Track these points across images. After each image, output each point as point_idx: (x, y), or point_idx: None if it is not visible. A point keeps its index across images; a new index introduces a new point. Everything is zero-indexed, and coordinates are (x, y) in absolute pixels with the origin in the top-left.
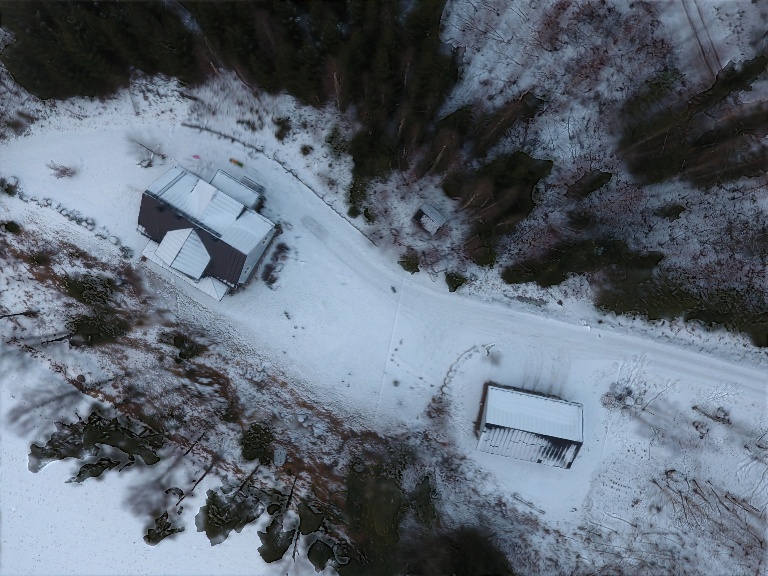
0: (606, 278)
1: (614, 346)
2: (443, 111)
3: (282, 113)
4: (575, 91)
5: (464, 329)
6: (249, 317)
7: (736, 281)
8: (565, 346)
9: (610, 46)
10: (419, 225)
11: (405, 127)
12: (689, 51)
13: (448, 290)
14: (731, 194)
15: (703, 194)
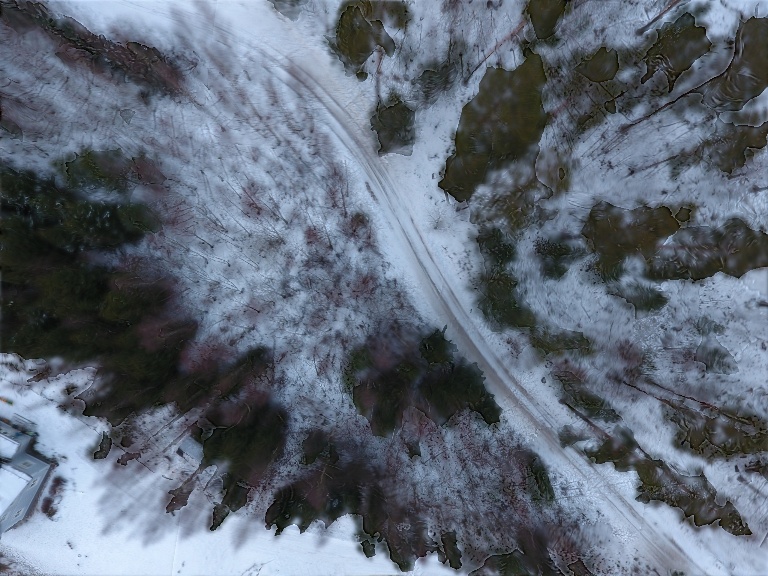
0: None
1: (387, 559)
2: (192, 353)
3: None
4: (316, 331)
5: (244, 548)
6: (34, 548)
7: (500, 493)
8: (340, 561)
9: (344, 288)
10: None
11: (123, 406)
12: (422, 289)
13: None
14: None
15: (457, 416)
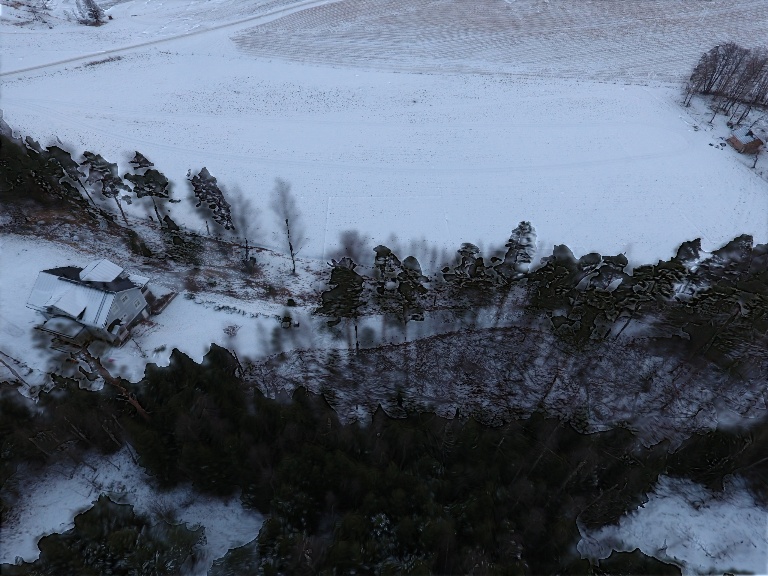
0: None
1: None
2: None
3: None
4: None
5: None
6: None
7: None
8: None
9: None
10: None
11: None
12: None
13: None
14: None
15: None
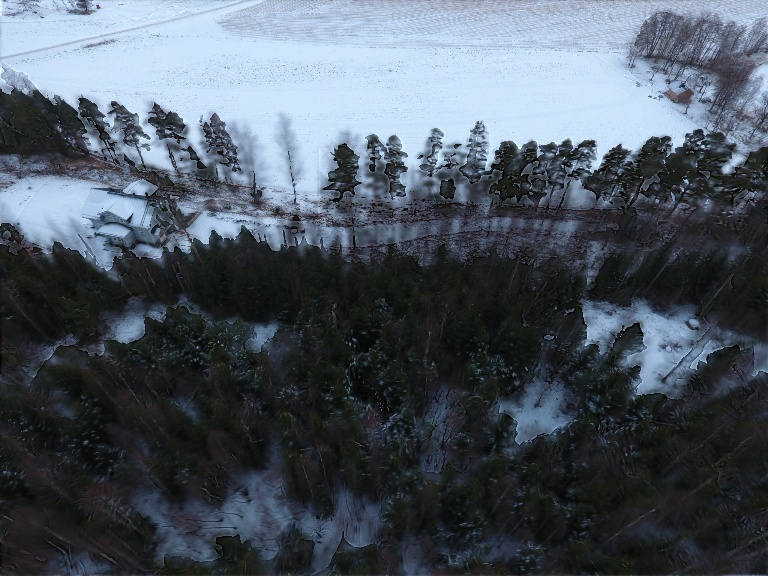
0: None
1: None
2: None
3: None
4: None
5: None
6: None
7: None
8: None
9: None
10: None
11: None
12: None
13: None
14: None
15: None
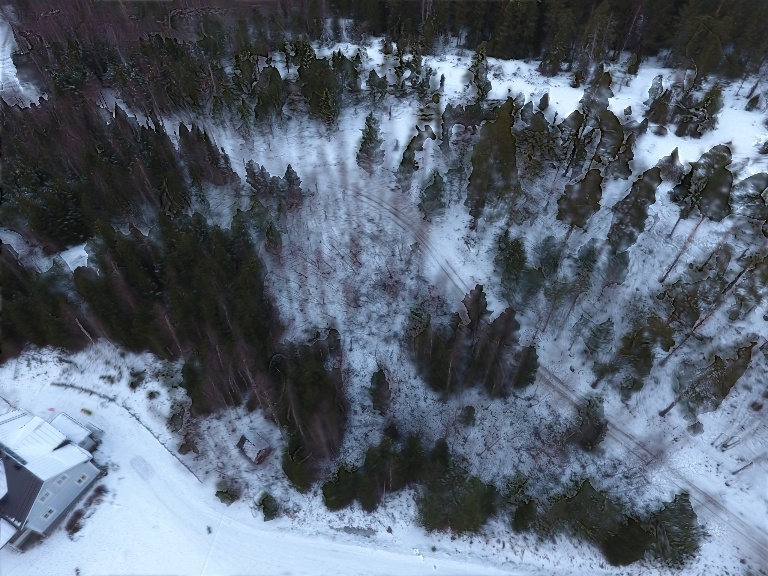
0: (432, 495)
1: None
2: None
3: (140, 366)
4: (378, 332)
5: (282, 574)
6: None
7: (563, 487)
8: None
9: (400, 302)
10: (246, 456)
11: (222, 355)
12: (459, 301)
13: (269, 526)
14: (528, 402)
15: (503, 404)
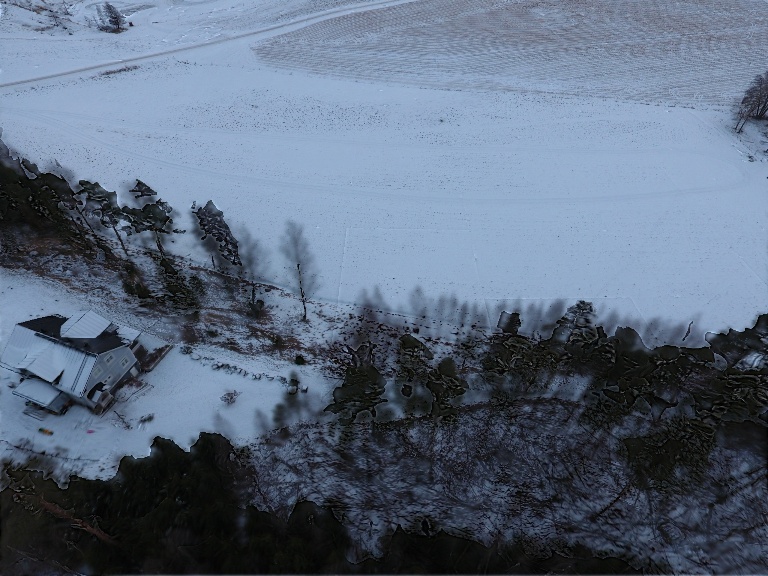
0: None
1: None
2: None
3: None
4: None
5: None
6: None
7: None
8: None
9: None
10: None
11: None
12: None
13: None
14: None
15: None
